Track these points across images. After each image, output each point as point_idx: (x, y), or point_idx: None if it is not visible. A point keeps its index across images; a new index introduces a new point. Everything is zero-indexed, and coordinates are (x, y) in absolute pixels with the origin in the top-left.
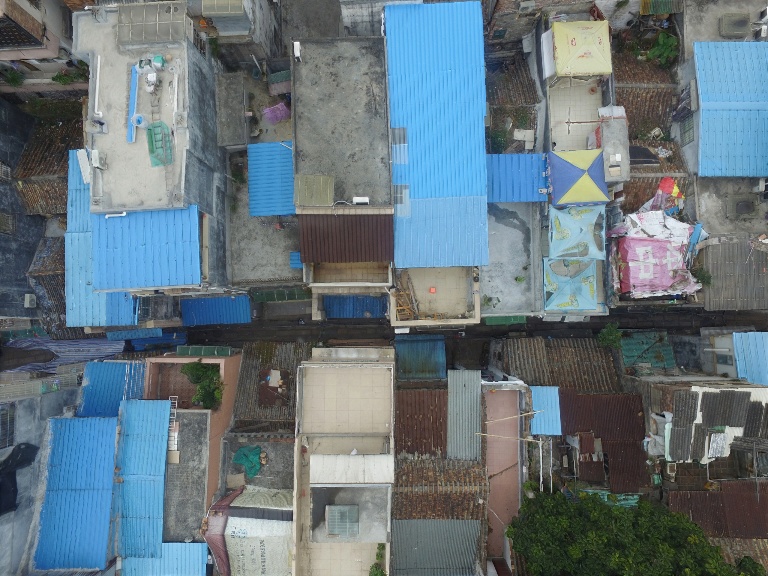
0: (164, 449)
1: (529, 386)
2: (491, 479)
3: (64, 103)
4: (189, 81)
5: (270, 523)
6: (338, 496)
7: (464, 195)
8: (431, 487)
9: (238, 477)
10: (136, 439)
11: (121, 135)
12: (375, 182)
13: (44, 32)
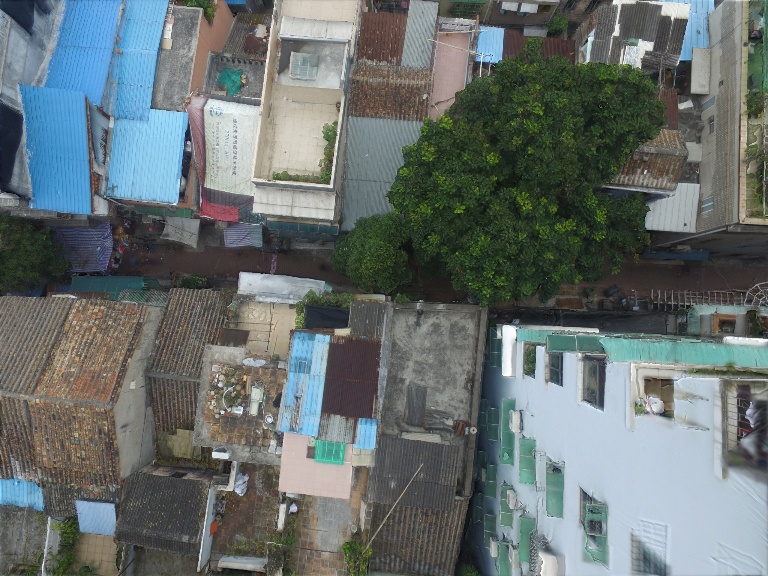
0: (160, 32)
1: (479, 26)
2: (438, 105)
3: None
4: None
5: (244, 106)
6: (303, 49)
7: None
8: (384, 79)
9: (221, 93)
10: (137, 22)
11: None
12: None
13: None
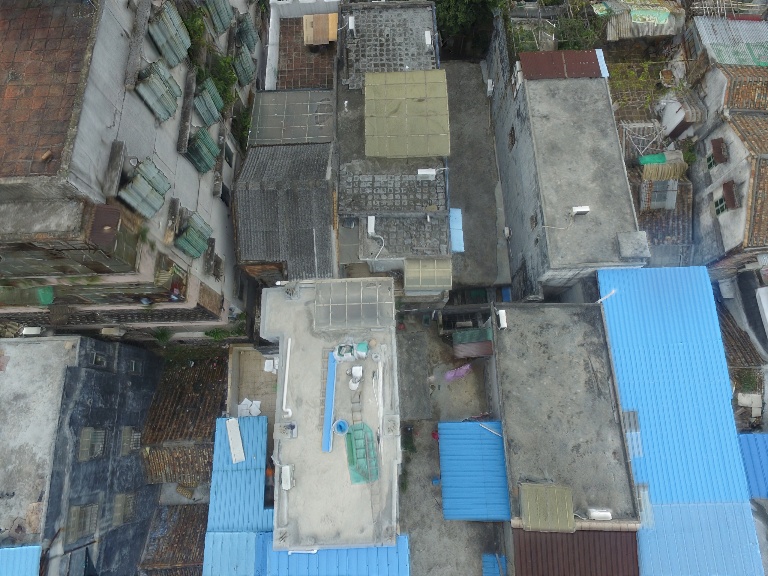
0: None
1: None
2: None
3: (206, 348)
4: (397, 372)
5: None
6: None
7: (720, 501)
8: None
9: None
10: None
11: (313, 440)
12: (609, 485)
13: (222, 304)
